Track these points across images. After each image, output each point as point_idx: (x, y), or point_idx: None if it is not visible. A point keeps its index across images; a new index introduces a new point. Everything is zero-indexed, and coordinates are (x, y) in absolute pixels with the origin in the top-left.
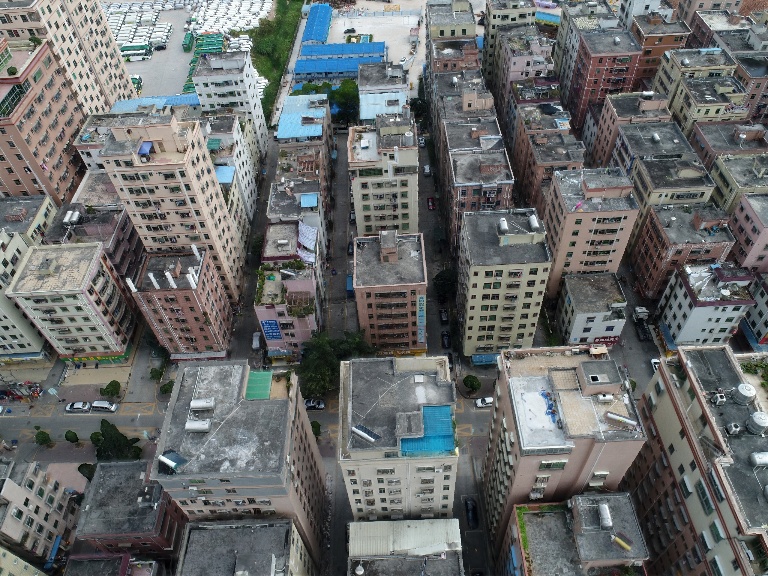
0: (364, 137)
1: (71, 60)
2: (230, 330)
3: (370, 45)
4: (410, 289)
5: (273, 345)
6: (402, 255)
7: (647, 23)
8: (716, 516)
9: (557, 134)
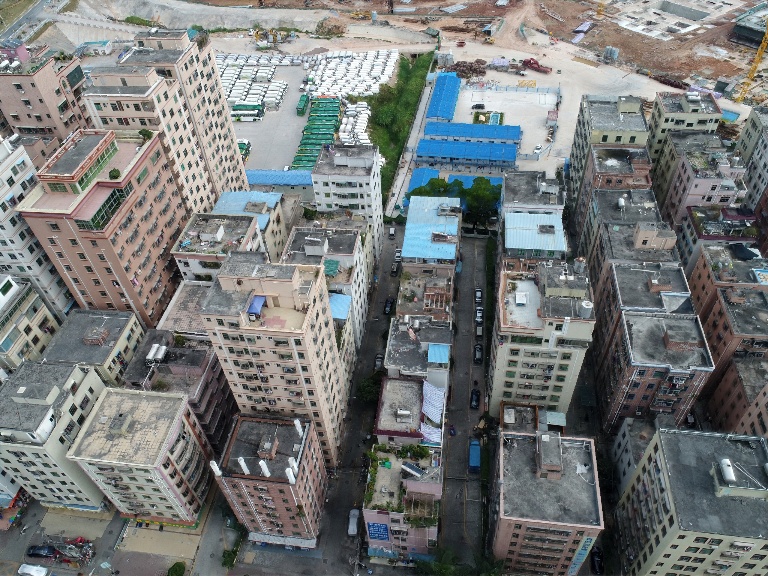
0: (519, 287)
1: (182, 149)
2: (323, 505)
3: (503, 129)
4: (577, 529)
5: (376, 543)
6: (565, 469)
7: None
8: None
9: (757, 291)
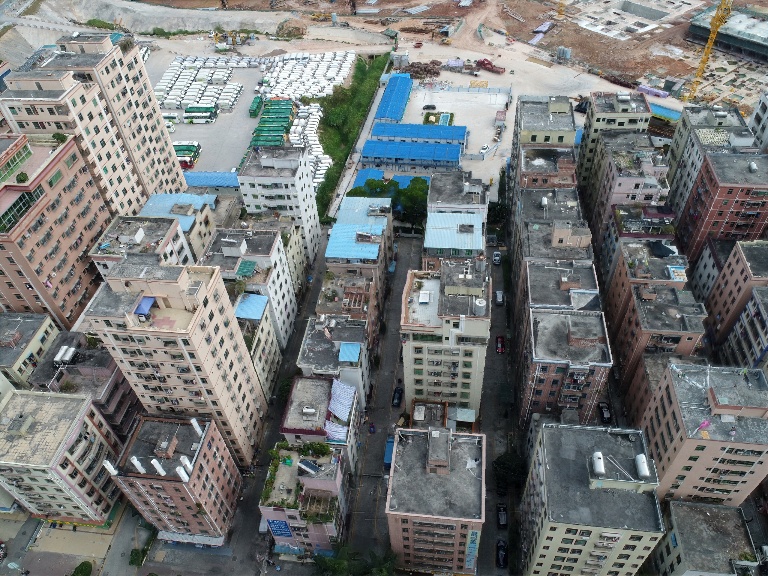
0: (425, 286)
1: (104, 153)
2: (235, 503)
3: (449, 130)
4: (460, 523)
5: (281, 540)
6: (455, 464)
7: None
8: None
9: (669, 288)
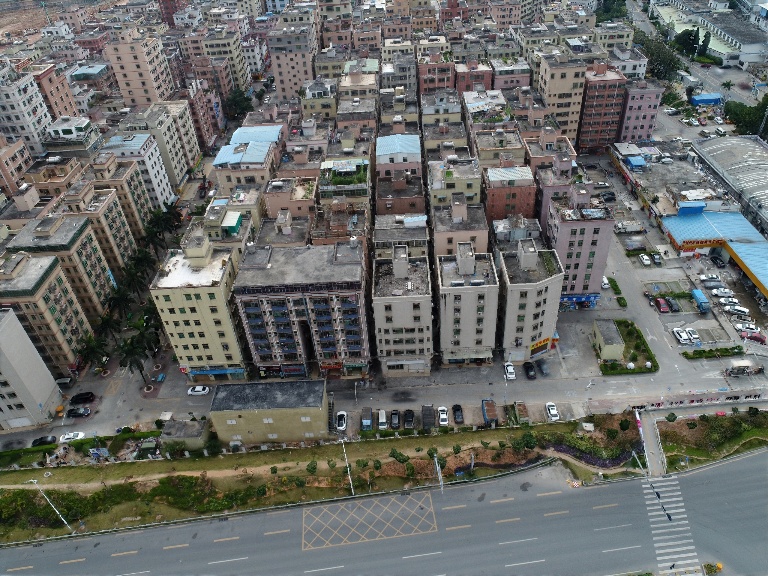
0: None
1: None
2: None
3: None
4: None
5: None
6: None
7: None
8: (335, 6)
9: None
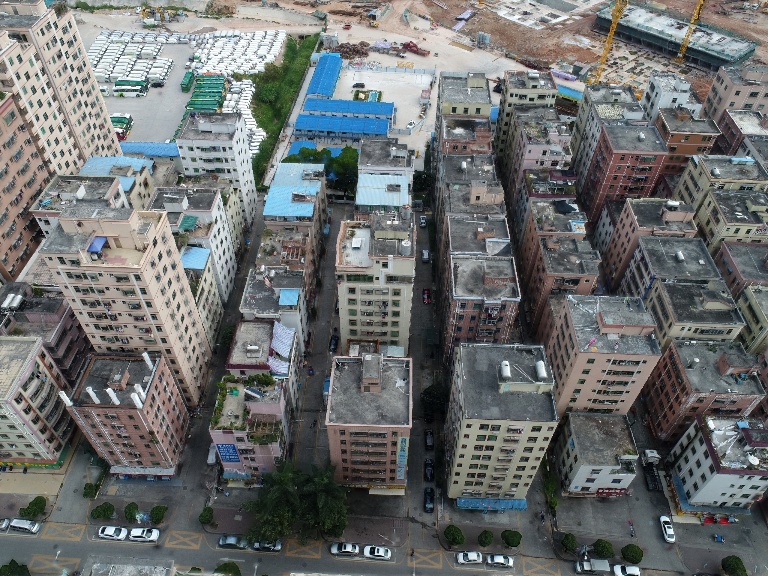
0: (357, 234)
1: (41, 113)
2: (184, 439)
3: (378, 105)
4: (391, 430)
5: (230, 466)
6: (386, 384)
7: (674, 118)
8: None
9: (571, 239)
